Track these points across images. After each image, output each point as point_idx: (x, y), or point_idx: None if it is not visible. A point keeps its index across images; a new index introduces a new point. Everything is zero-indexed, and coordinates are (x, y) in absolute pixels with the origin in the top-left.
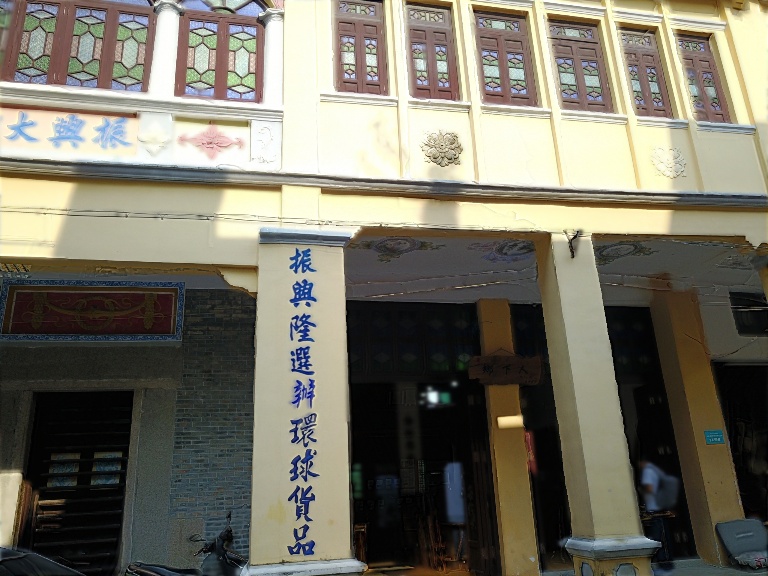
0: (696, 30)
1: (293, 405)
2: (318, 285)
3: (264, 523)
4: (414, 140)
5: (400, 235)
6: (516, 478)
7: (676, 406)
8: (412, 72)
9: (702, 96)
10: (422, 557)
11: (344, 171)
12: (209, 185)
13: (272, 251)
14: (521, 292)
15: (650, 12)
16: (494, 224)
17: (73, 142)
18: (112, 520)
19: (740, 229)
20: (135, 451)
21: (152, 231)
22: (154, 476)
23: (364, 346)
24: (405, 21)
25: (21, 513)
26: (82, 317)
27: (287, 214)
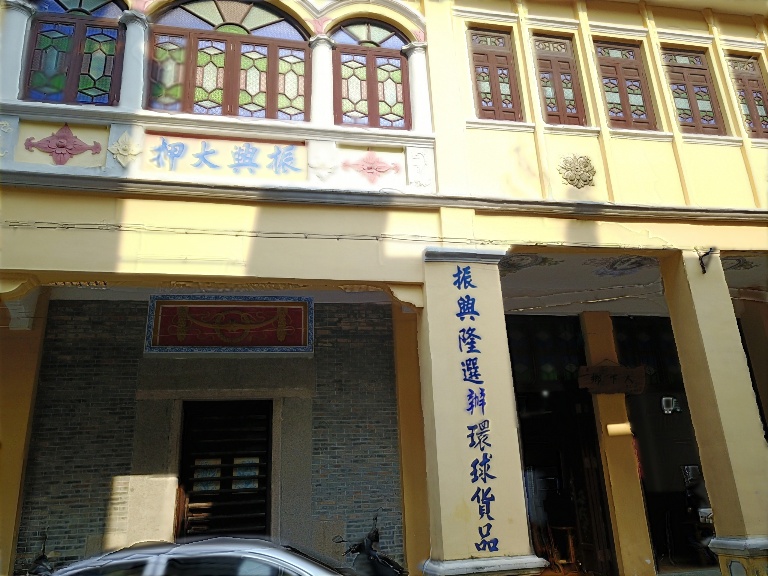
0: None
1: (468, 412)
2: (479, 300)
3: (452, 521)
4: (551, 164)
5: (529, 252)
6: (628, 483)
7: None
8: (542, 99)
9: None
10: None
11: (492, 193)
12: (376, 208)
13: (437, 269)
14: (621, 305)
15: (753, 39)
16: (629, 242)
17: (251, 169)
18: (255, 522)
19: None
20: (278, 457)
21: (329, 251)
22: (296, 480)
23: None
24: (532, 51)
25: (177, 515)
26: (221, 330)
27: (447, 234)
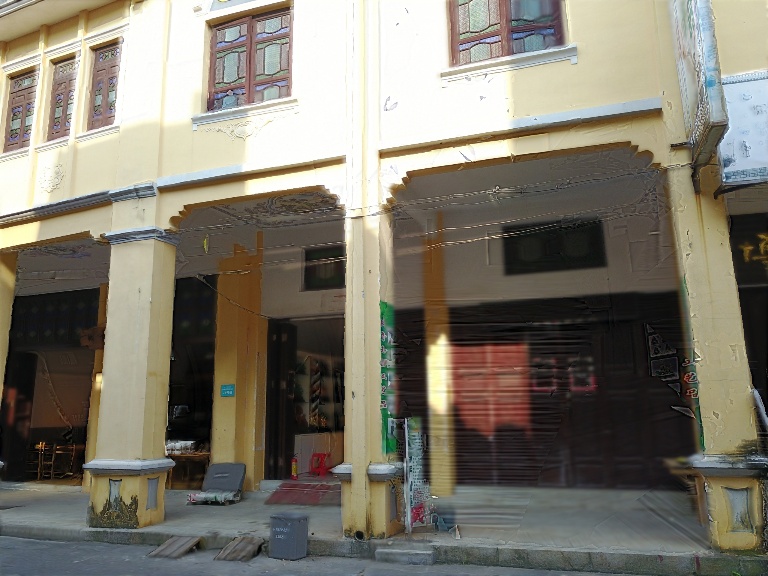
0: (109, 39)
1: None
2: None
3: None
4: None
5: None
6: None
7: None
8: None
9: (104, 103)
10: (77, 468)
11: None
12: None
13: None
14: None
15: (74, 39)
16: None
17: None
18: None
19: (86, 225)
20: None
21: None
22: None
23: (38, 326)
24: None
25: None
26: None
27: None
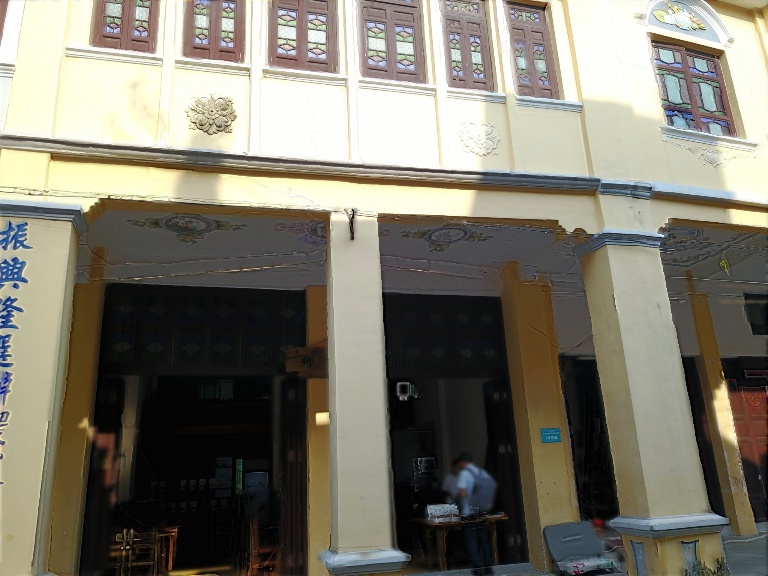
0: None
1: None
2: (33, 264)
3: None
4: (179, 104)
5: (180, 212)
6: None
7: (517, 401)
8: (190, 29)
9: (530, 69)
10: (229, 564)
11: (87, 136)
12: None
13: None
14: None
15: None
16: (265, 200)
17: None
18: None
19: (553, 212)
20: None
21: None
22: None
23: (171, 335)
24: None
25: None
26: None
27: (3, 182)
